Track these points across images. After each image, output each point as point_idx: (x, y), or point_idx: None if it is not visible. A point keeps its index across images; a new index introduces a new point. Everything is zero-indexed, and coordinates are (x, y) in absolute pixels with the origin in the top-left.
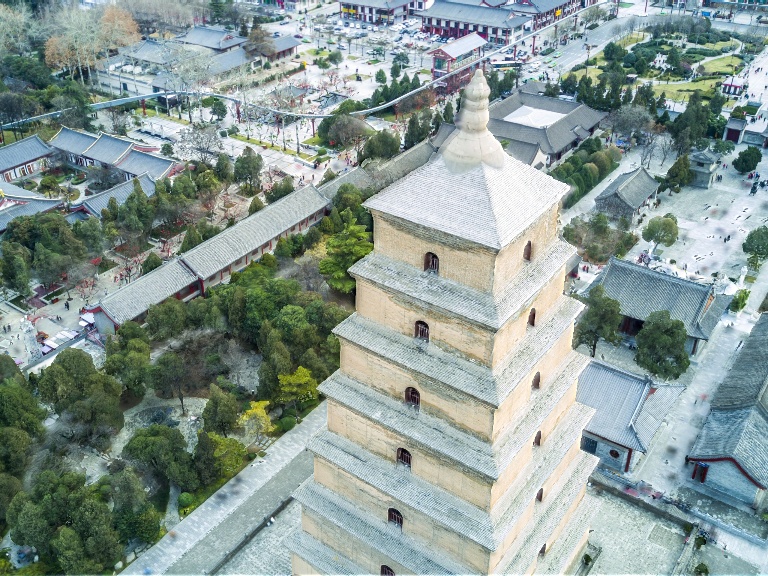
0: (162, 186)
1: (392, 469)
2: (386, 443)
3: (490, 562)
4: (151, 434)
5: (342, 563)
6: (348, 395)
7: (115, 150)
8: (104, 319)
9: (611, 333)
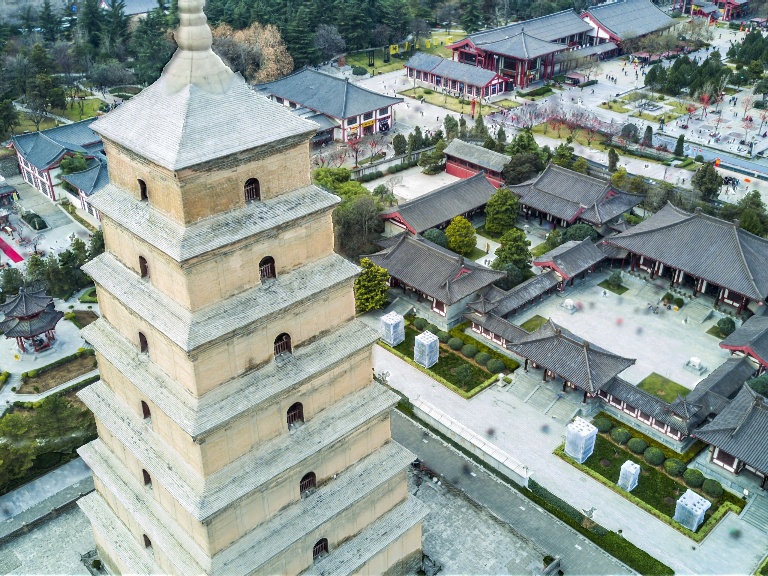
0: None
1: None
2: None
3: None
4: None
5: None
6: None
7: None
8: None
9: None
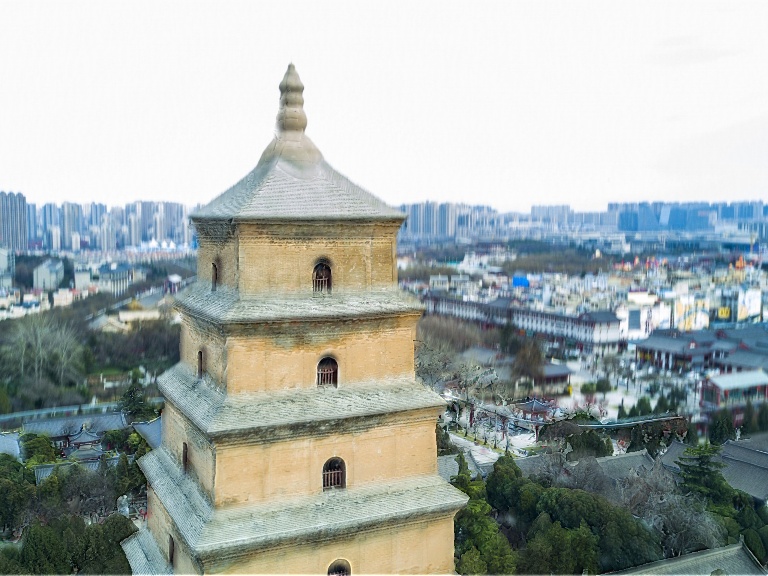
0: None
1: (163, 570)
2: (165, 531)
3: None
4: None
5: None
6: (151, 464)
7: None
8: None
9: None
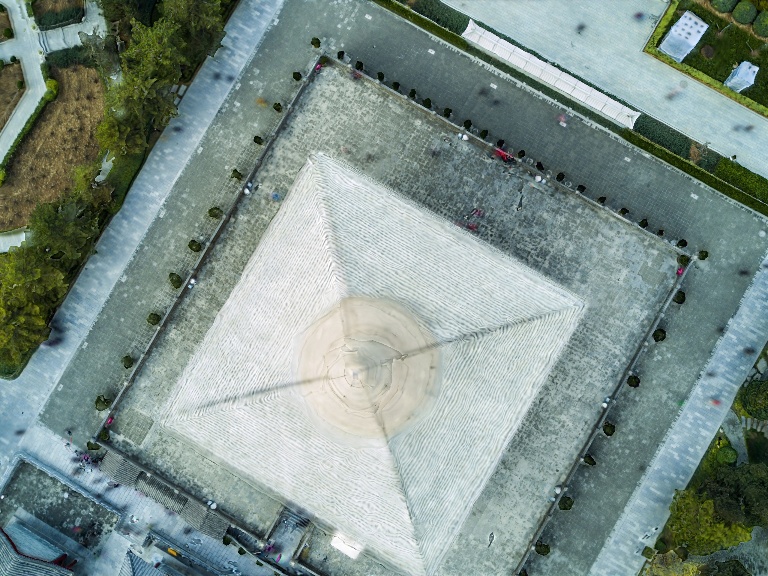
0: None
1: None
2: None
3: None
4: None
5: None
6: None
7: None
8: None
9: None
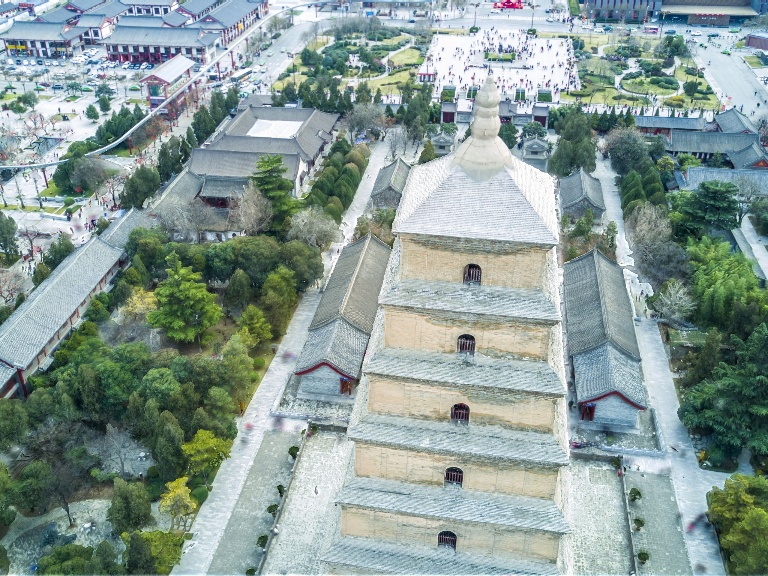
0: None
1: (441, 492)
2: (432, 468)
3: None
4: (60, 559)
5: None
6: (386, 432)
7: None
8: None
9: None
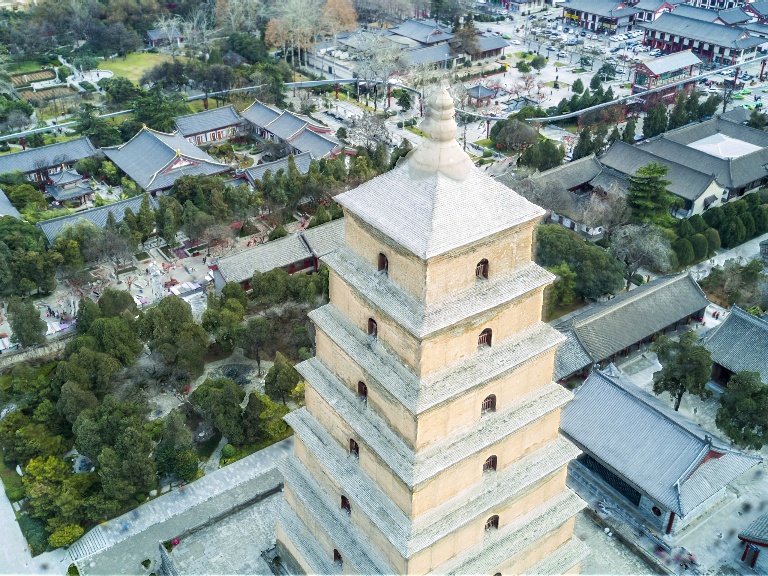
0: (315, 165)
1: (345, 458)
2: (342, 431)
3: (411, 570)
4: (216, 386)
5: (308, 538)
6: (316, 378)
7: (292, 127)
8: (220, 277)
9: (695, 385)
